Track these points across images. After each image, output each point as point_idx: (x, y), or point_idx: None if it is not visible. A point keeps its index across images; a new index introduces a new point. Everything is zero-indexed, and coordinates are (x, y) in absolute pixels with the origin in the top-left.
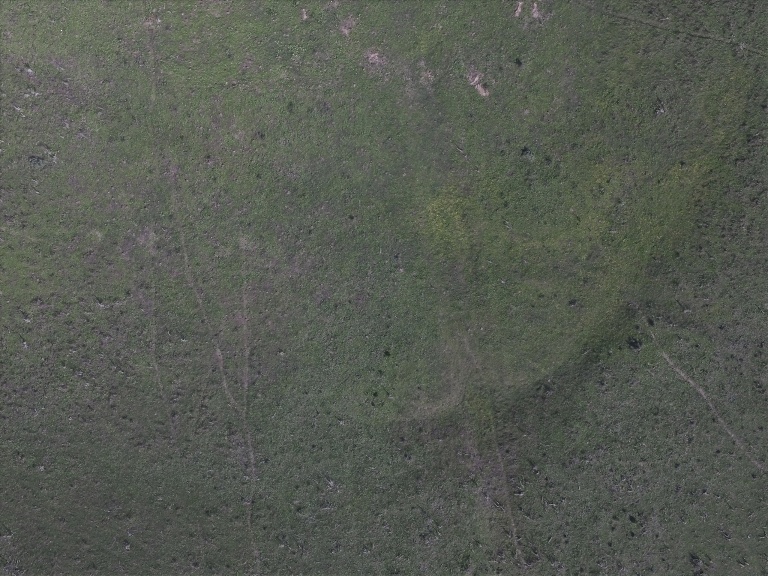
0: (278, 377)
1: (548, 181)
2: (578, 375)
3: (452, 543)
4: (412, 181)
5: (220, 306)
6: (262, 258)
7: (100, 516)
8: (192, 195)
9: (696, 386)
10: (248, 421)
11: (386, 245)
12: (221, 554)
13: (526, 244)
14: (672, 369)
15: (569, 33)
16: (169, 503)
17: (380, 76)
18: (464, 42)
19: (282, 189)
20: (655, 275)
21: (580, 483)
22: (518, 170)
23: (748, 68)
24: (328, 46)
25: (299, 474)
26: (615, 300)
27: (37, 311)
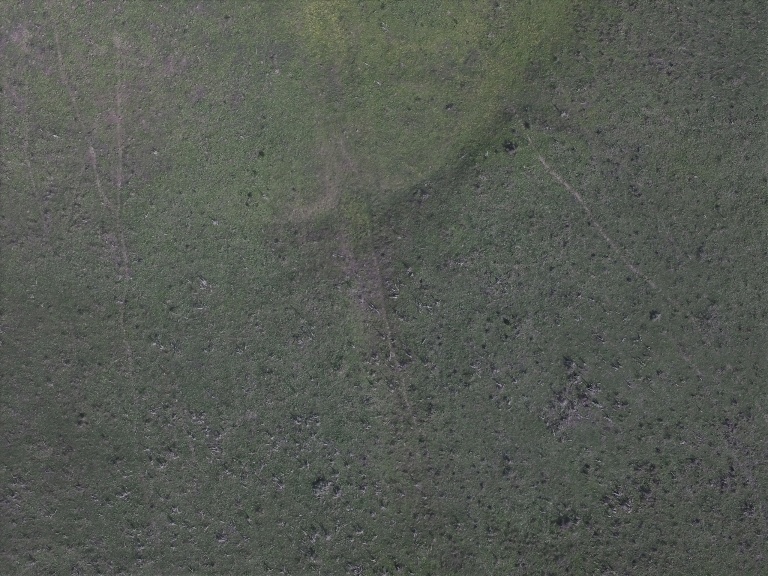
0: (152, 176)
1: None
2: (454, 179)
3: (325, 344)
4: None
5: (93, 104)
6: (137, 57)
7: None
8: None
9: (572, 190)
10: (121, 220)
11: (262, 46)
12: (93, 352)
13: (403, 47)
14: (548, 172)
15: None
16: (42, 301)
17: None
18: None
19: None
20: (532, 79)
21: (454, 285)
22: None
23: None
24: None
25: (172, 274)
26: (492, 105)
27: None
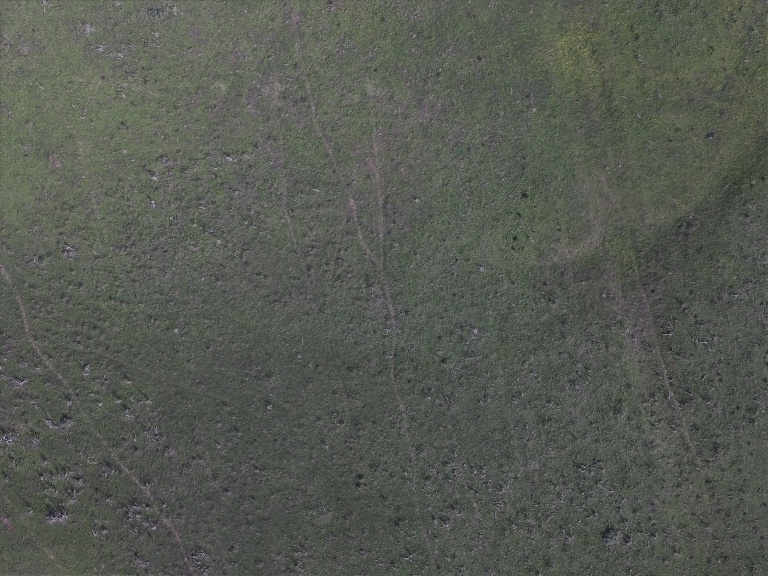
0: (414, 225)
1: (679, 11)
2: (721, 209)
3: (603, 387)
4: (539, 18)
5: (351, 155)
6: (391, 104)
7: (238, 377)
8: (316, 43)
9: None
10: (386, 272)
11: (517, 85)
12: (366, 410)
13: (659, 77)
14: None
15: None
16: (309, 361)
17: None
18: None
19: (407, 32)
20: None
21: (730, 319)
22: (647, 2)
23: None
24: None
25: (441, 324)
26: (753, 131)
27: (163, 169)
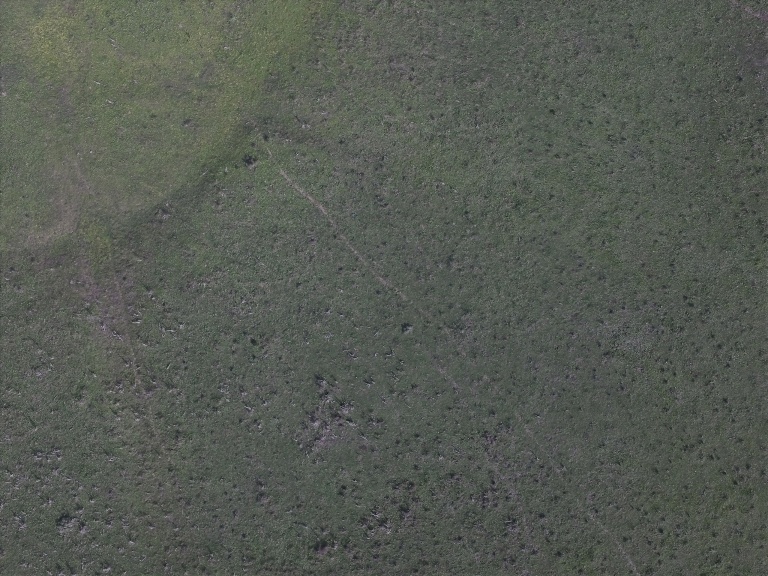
0: None
1: None
2: (195, 197)
3: (65, 374)
4: (12, 2)
5: None
6: None
7: None
8: None
9: (316, 203)
10: None
11: None
12: None
13: (136, 63)
14: (290, 186)
15: None
16: None
17: None
18: None
19: None
20: (271, 91)
21: (198, 307)
22: None
23: None
24: None
25: None
26: (232, 119)
27: None
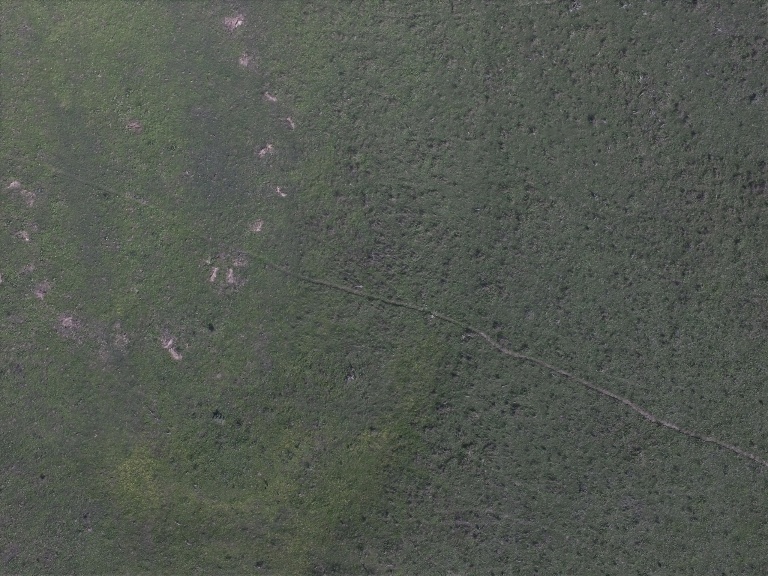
0: None
1: (237, 445)
2: None
3: None
4: (103, 442)
5: None
6: None
7: None
8: None
9: None
10: None
11: (76, 504)
12: None
13: (215, 506)
14: None
15: (265, 298)
16: None
17: (74, 339)
18: (159, 306)
19: None
20: (341, 539)
21: None
22: (209, 432)
23: (440, 336)
24: (23, 309)
25: None
26: (302, 562)
27: None
